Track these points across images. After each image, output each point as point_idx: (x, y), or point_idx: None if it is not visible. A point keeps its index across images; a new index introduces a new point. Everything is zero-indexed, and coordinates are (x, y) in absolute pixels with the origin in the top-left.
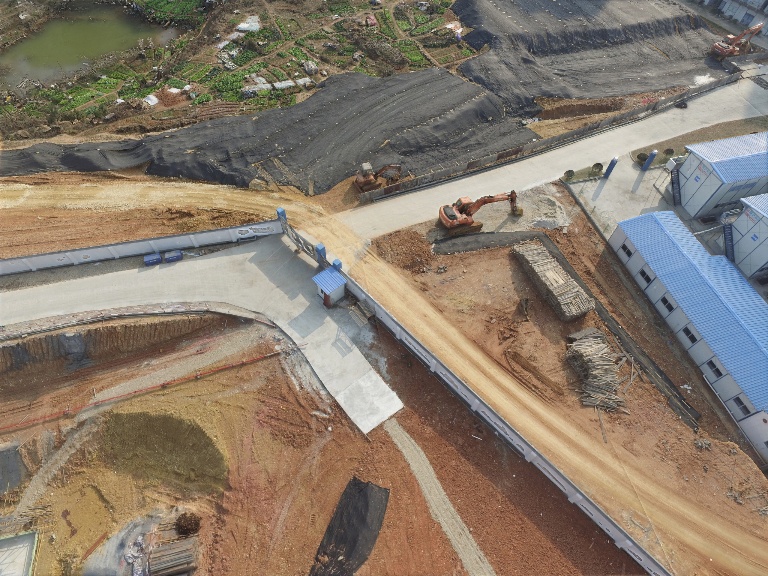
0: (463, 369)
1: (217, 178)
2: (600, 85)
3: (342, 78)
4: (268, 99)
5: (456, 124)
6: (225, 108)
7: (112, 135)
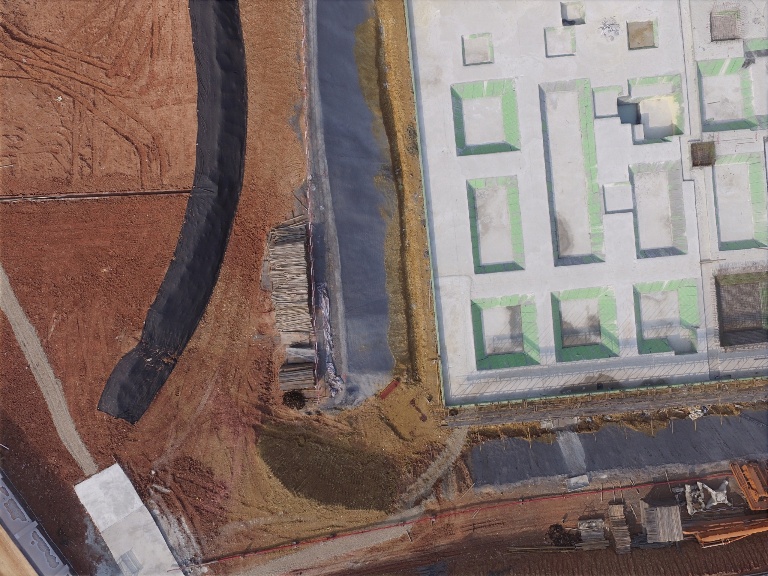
0: None
1: None
2: None
3: None
4: None
5: None
6: None
7: None
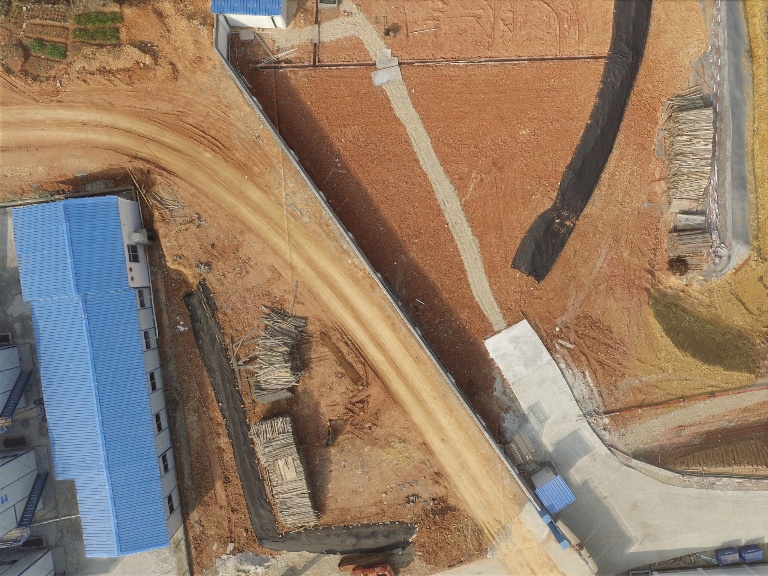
0: (416, 373)
1: None
2: None
3: None
4: None
5: None
6: None
7: None
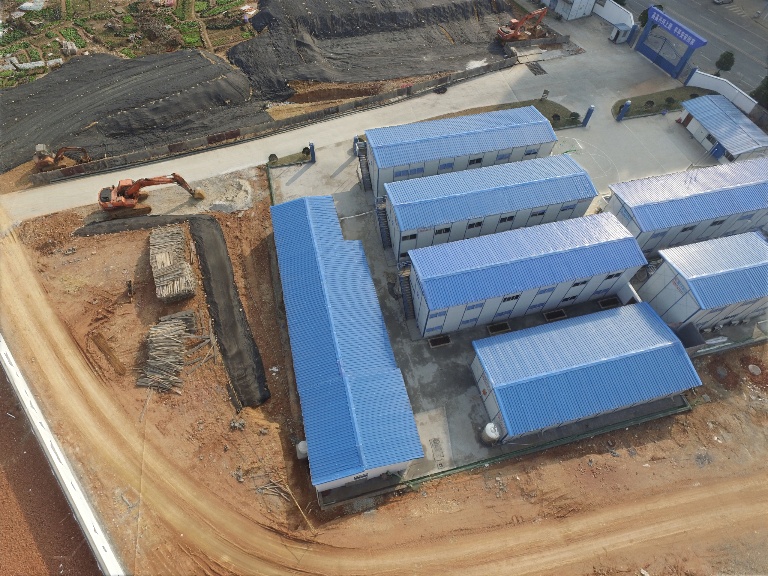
0: (37, 349)
1: None
2: (368, 69)
3: (83, 59)
4: (8, 80)
5: (181, 107)
6: None
7: None
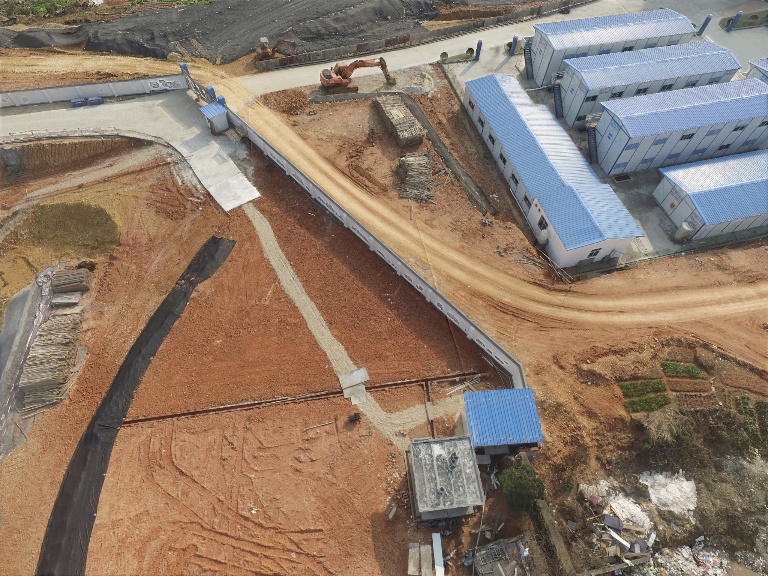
0: (313, 175)
1: (142, 52)
2: None
3: None
4: (198, 0)
5: (355, 18)
6: (159, 6)
7: (60, 24)
